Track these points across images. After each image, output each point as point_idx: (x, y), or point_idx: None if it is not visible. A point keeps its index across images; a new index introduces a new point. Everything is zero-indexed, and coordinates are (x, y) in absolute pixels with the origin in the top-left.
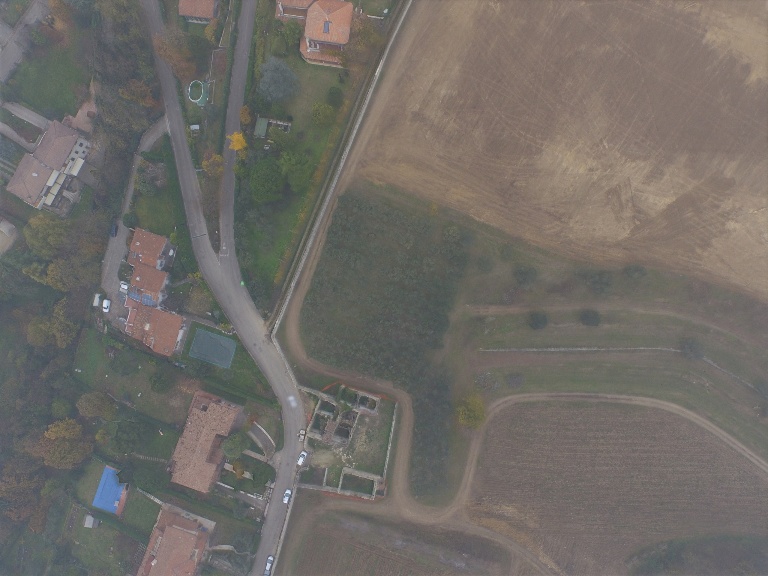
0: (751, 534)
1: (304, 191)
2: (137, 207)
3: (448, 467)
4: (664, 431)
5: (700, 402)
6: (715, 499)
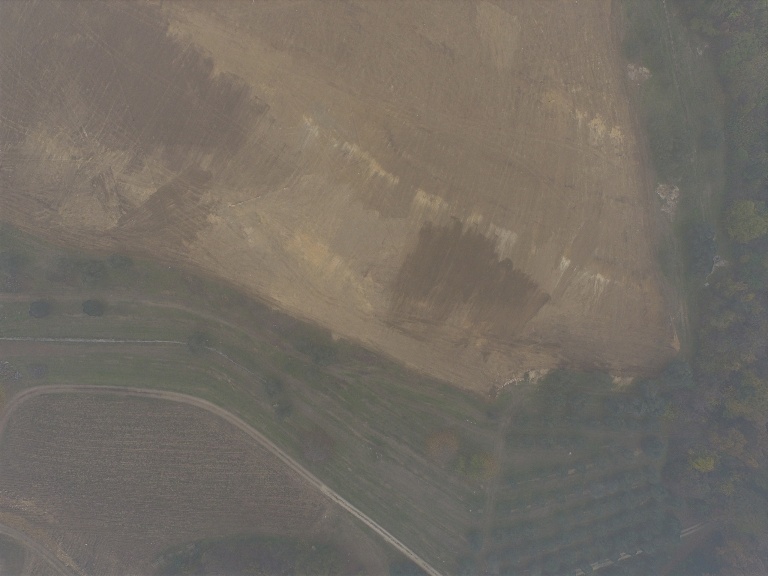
0: (282, 536)
1: None
2: None
3: None
4: (193, 427)
5: (227, 398)
6: (245, 499)
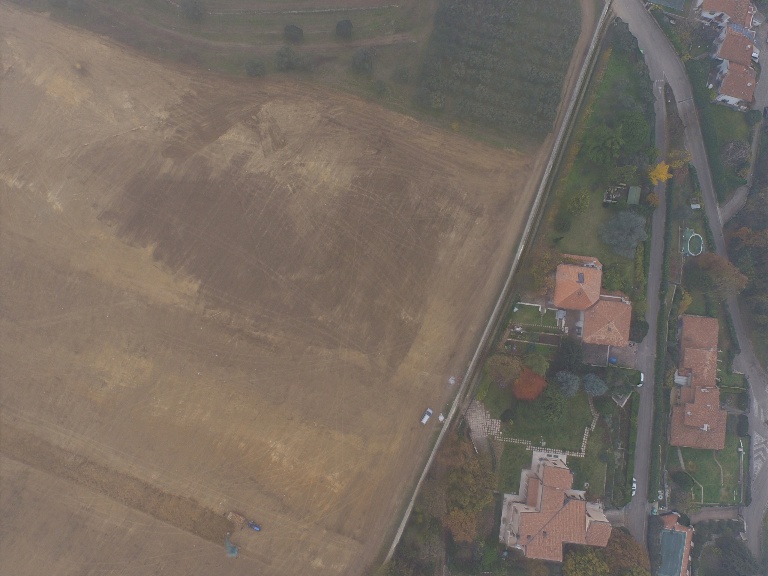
0: None
1: None
2: (747, 133)
3: None
4: None
5: None
6: None
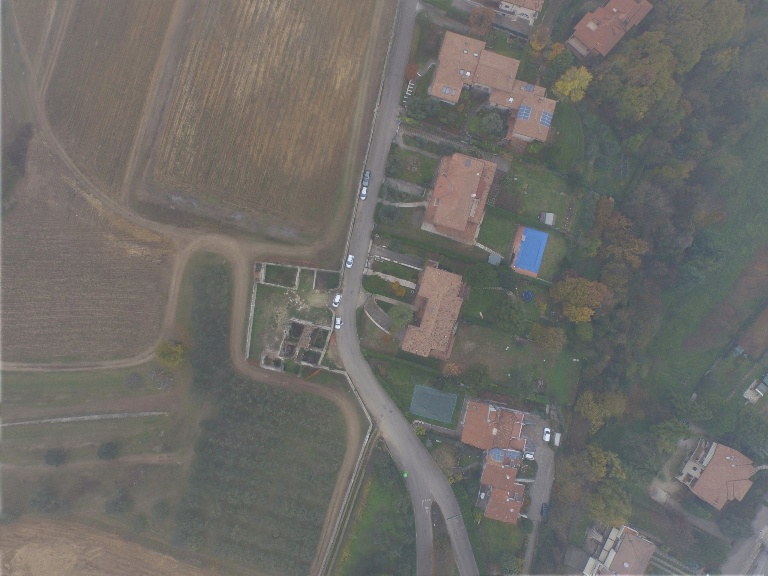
0: None
1: None
2: (521, 538)
3: None
4: None
5: None
6: None
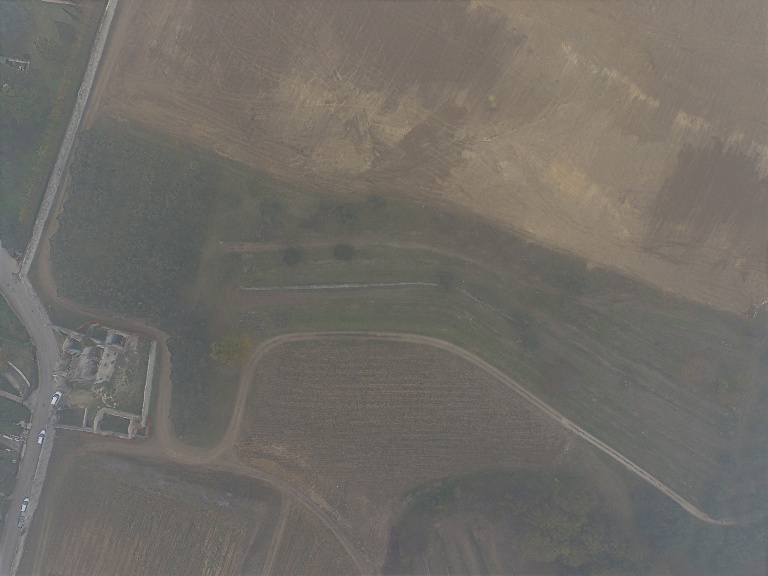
0: (525, 470)
1: (42, 128)
2: None
3: (210, 406)
4: (434, 368)
5: (467, 337)
6: (487, 435)
